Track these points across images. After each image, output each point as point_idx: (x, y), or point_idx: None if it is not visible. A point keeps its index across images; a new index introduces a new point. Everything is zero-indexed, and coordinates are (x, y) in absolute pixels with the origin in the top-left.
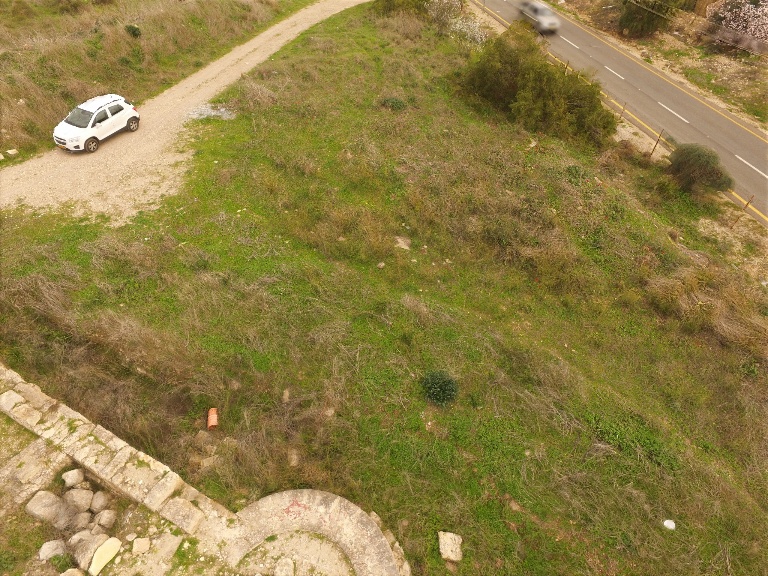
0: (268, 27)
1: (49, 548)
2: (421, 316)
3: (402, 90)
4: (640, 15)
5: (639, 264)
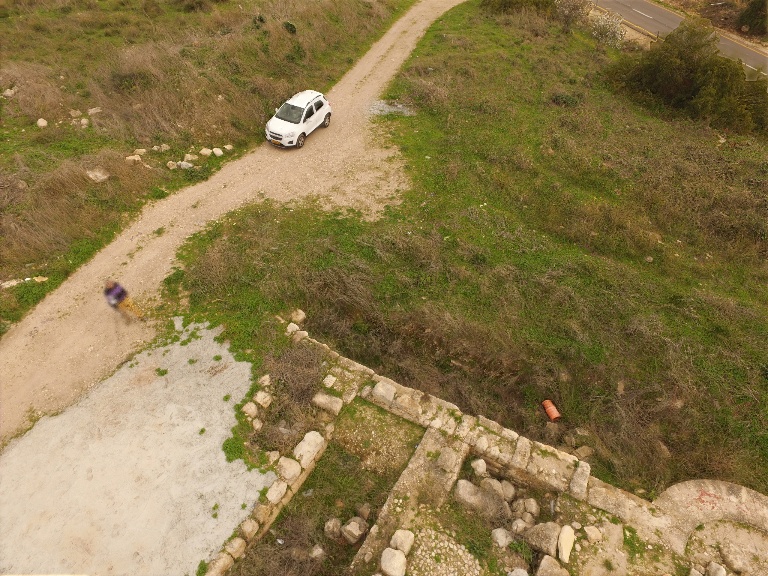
0: (391, 24)
1: (502, 536)
2: (726, 309)
3: (563, 86)
4: (763, 12)
5: None
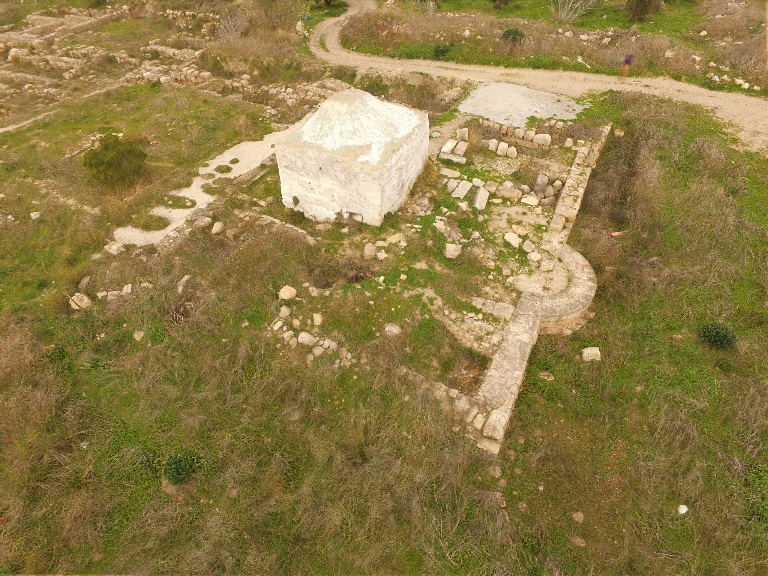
0: None
1: (526, 187)
2: None
3: None
4: None
5: None
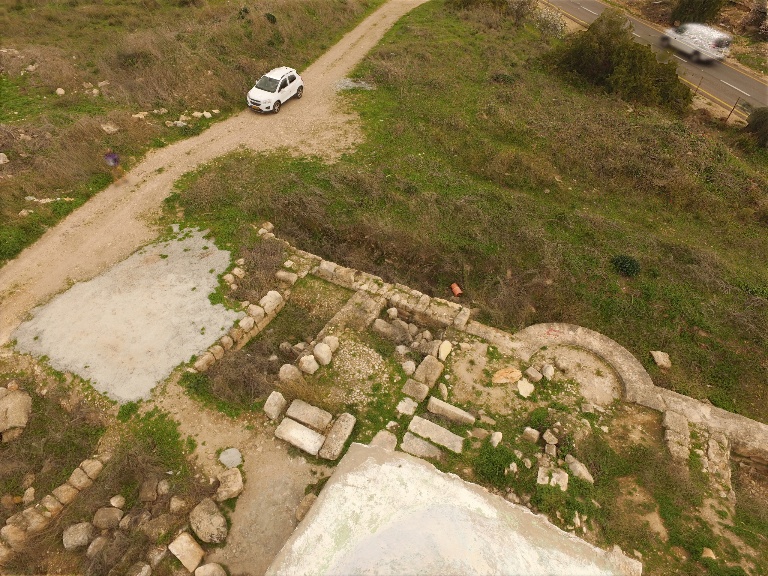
0: (363, 18)
1: (402, 348)
2: (596, 222)
3: (506, 68)
4: (691, 8)
5: (746, 191)
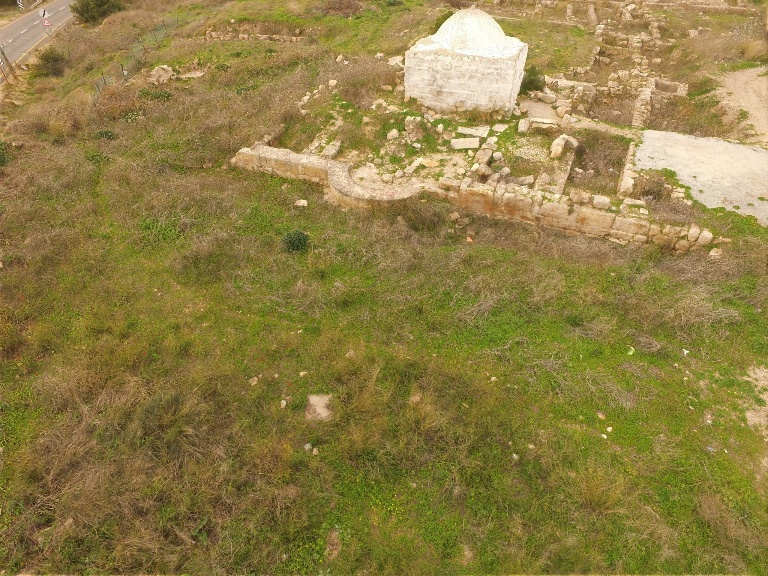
0: None
1: None
2: None
3: None
4: None
5: None
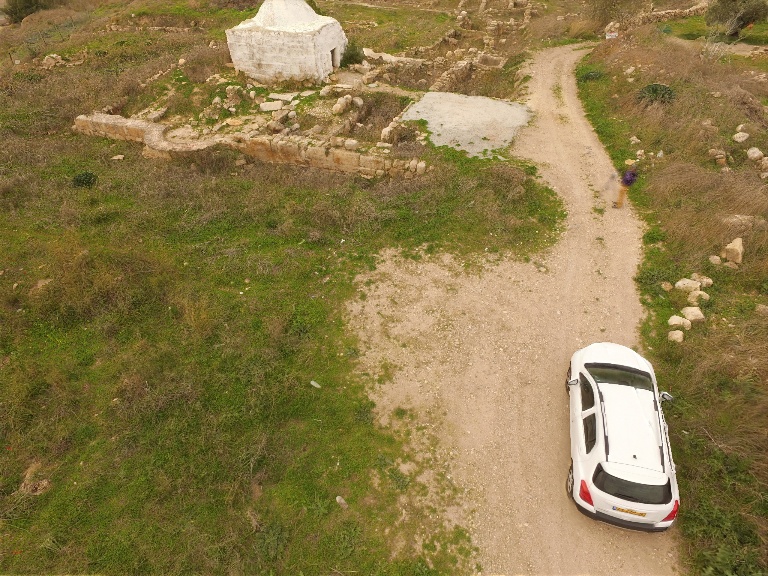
0: None
1: (295, 125)
2: None
3: None
4: None
5: None
